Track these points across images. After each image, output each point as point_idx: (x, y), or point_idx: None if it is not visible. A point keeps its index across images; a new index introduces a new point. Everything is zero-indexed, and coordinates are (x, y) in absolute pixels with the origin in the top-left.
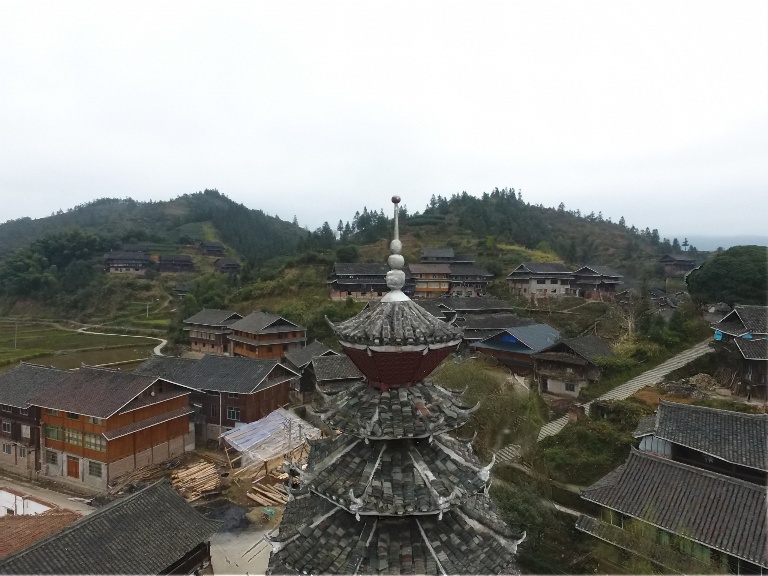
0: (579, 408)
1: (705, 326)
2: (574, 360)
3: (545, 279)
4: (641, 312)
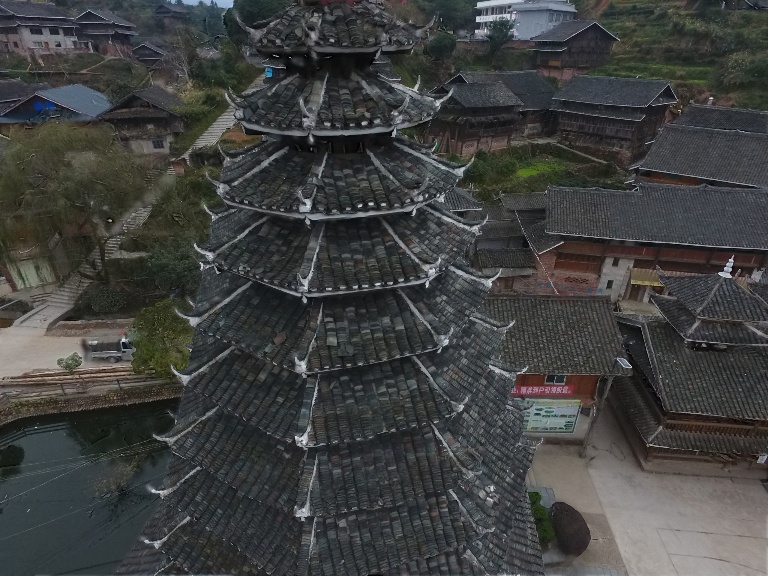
0: (181, 160)
1: (251, 67)
2: (153, 113)
3: (40, 27)
4: (193, 57)
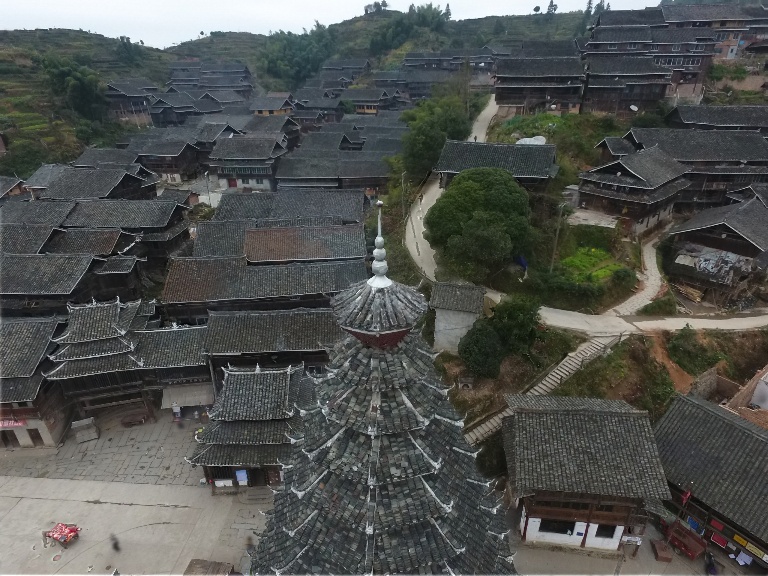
0: None
1: None
2: None
3: None
4: None
